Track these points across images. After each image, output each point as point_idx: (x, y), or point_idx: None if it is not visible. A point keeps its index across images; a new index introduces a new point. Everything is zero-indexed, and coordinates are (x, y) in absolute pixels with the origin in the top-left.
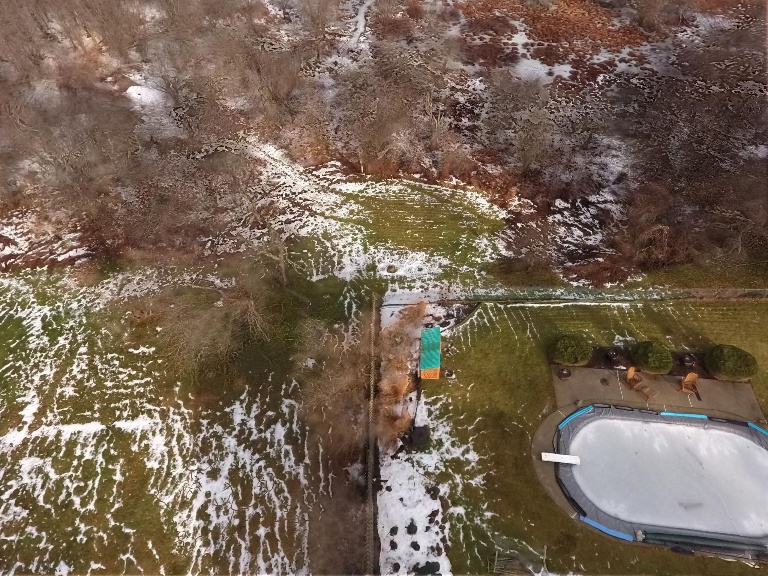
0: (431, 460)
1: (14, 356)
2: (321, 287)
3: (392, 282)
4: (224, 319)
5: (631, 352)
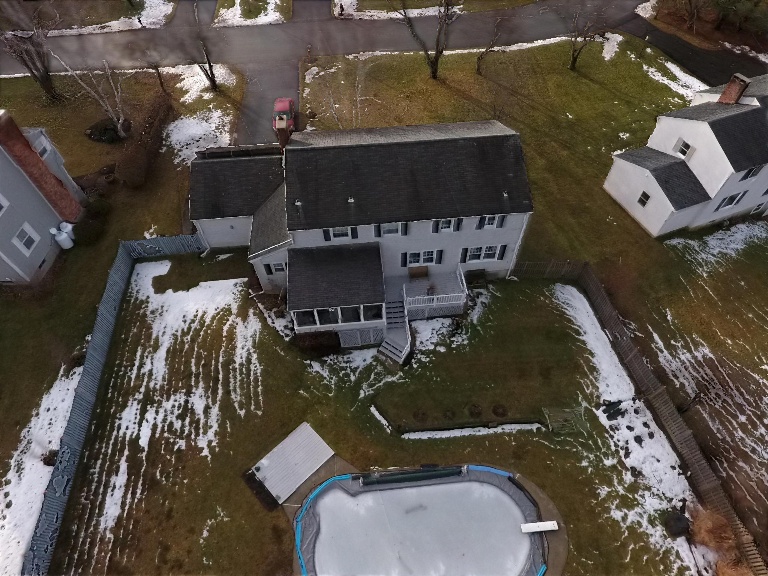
0: (652, 503)
1: None
2: None
3: None
4: None
5: None
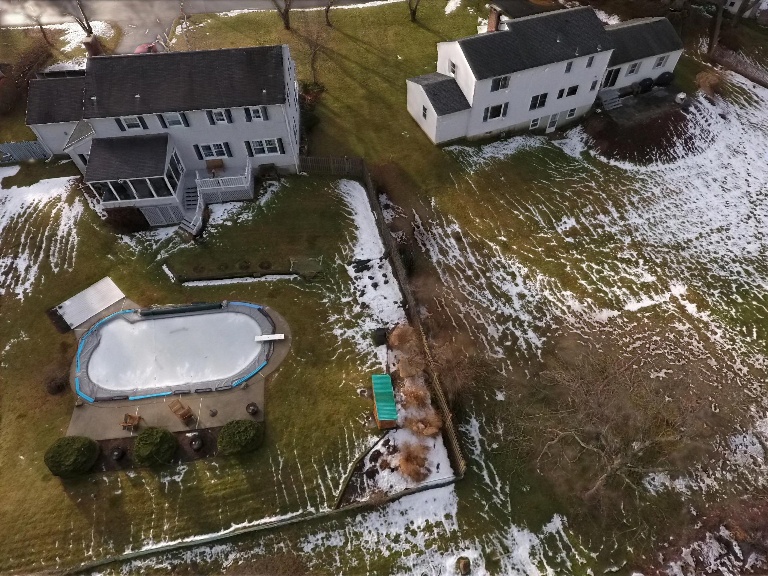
0: (369, 325)
1: (761, 344)
2: (540, 503)
3: (455, 534)
4: (615, 425)
5: (174, 450)
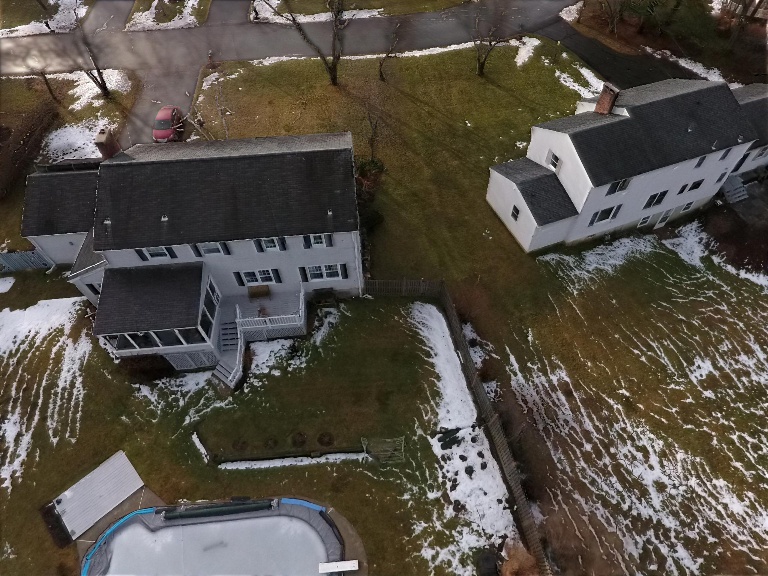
0: (468, 540)
1: None
2: None
3: None
4: None
5: None
